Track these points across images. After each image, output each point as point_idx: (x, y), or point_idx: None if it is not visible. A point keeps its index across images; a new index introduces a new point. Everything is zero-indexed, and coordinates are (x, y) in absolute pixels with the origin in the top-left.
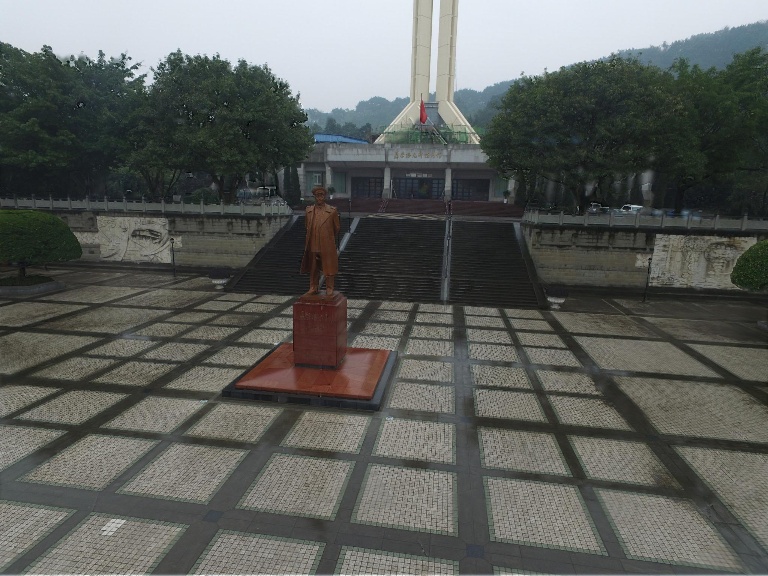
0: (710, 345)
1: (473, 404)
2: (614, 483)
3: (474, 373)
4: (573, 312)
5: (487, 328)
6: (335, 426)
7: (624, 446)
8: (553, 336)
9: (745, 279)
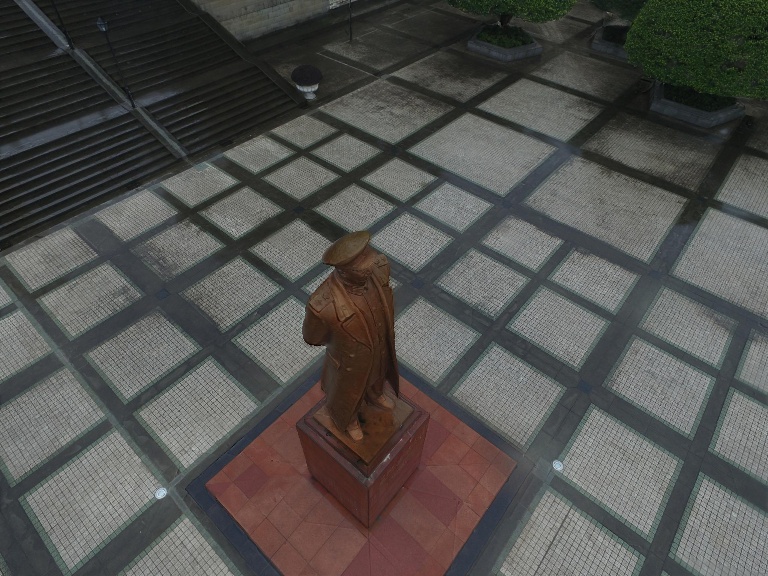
0: (489, 99)
1: (548, 355)
2: (728, 358)
3: (464, 298)
4: (337, 98)
5: (328, 192)
6: (562, 550)
7: (667, 303)
8: (398, 163)
9: (472, 2)
